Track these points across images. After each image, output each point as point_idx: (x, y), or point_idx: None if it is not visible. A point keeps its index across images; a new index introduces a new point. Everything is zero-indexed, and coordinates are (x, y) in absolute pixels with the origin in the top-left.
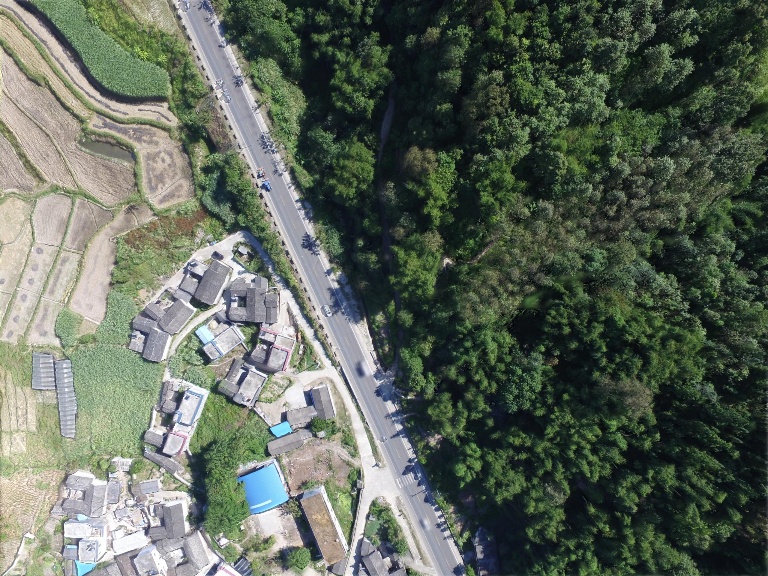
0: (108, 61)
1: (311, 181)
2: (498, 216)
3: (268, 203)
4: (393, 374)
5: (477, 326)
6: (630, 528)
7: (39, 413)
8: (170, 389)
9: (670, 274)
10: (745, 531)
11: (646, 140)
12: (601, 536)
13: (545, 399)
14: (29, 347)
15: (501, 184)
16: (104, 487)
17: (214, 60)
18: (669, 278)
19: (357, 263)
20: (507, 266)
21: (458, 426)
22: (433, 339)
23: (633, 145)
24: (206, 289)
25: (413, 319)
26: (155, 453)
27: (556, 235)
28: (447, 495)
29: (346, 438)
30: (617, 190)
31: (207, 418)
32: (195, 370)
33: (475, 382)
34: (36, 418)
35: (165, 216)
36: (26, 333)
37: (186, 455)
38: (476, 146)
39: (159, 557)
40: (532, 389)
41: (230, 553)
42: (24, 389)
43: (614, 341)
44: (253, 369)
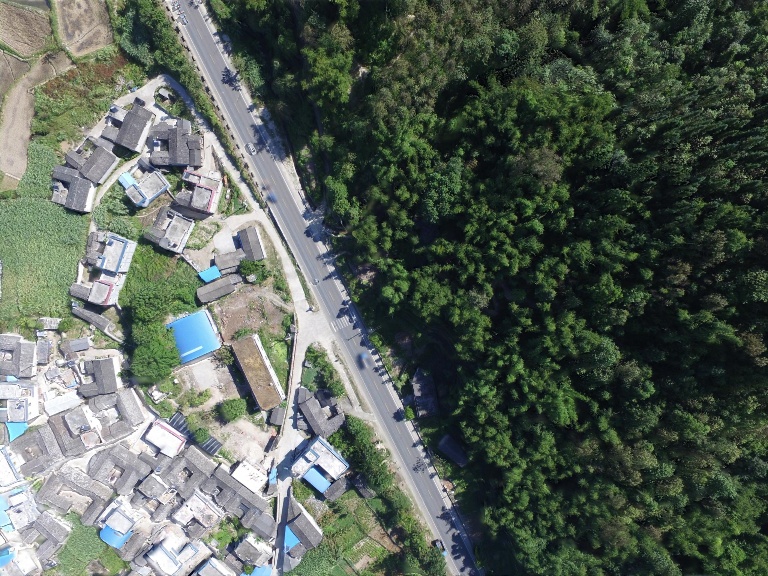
0: None
1: (228, 12)
2: None
3: (185, 37)
4: (322, 213)
5: (393, 128)
6: (551, 316)
7: None
8: (95, 240)
9: (587, 66)
10: (659, 293)
11: None
12: (525, 333)
13: (463, 195)
14: None
15: None
16: (32, 346)
17: None
18: (585, 68)
19: (278, 93)
20: (416, 54)
21: (383, 245)
22: (354, 157)
23: None
24: (126, 132)
25: (334, 140)
26: (84, 309)
27: (463, 14)
28: (379, 328)
29: (277, 282)
30: None
31: (135, 270)
32: (120, 219)
33: (397, 196)
34: None
35: (83, 63)
36: None
37: (116, 311)
38: None
39: (92, 415)
40: (451, 190)
41: (165, 408)
42: None
43: (528, 126)
44: None
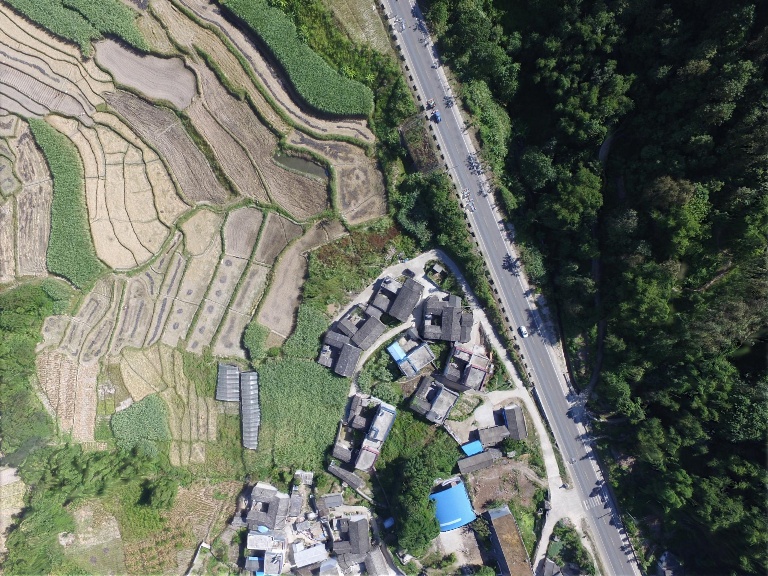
0: (316, 78)
1: (515, 203)
2: (762, 249)
3: (472, 223)
4: (586, 396)
5: (709, 355)
6: None
7: (220, 424)
8: (359, 404)
9: None
10: None
11: None
12: None
13: None
14: (214, 358)
15: None
16: (288, 500)
17: (426, 81)
18: None
19: (561, 286)
20: (753, 297)
21: (671, 452)
22: (649, 365)
23: None
24: (402, 307)
25: (625, 344)
26: (339, 467)
27: None
28: (644, 519)
29: (535, 459)
30: None
31: (393, 434)
32: (385, 386)
33: (693, 409)
34: (217, 429)
35: (358, 232)
36: (213, 344)
37: None
38: (741, 179)
39: (341, 571)
40: (763, 419)
41: (412, 569)
42: (207, 400)
43: None
44: (444, 387)
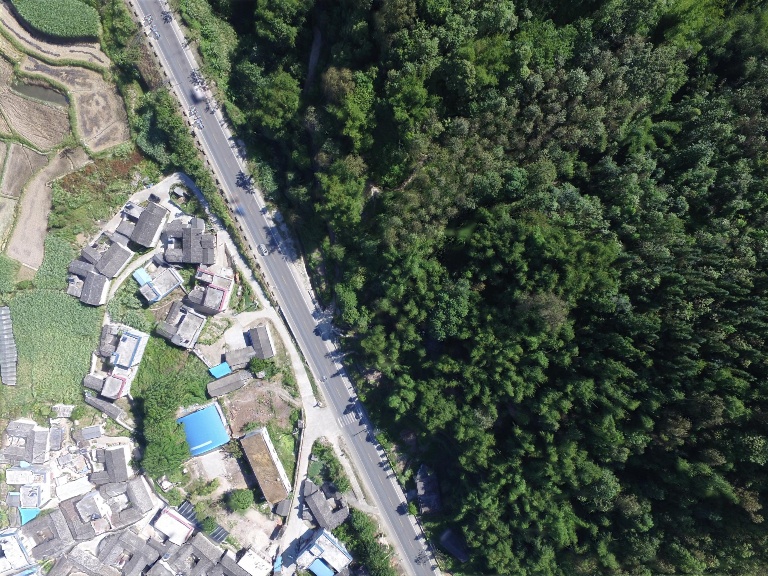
0: None
1: (243, 118)
2: (413, 132)
3: (201, 141)
4: (331, 313)
5: (403, 252)
6: (554, 446)
7: None
8: (109, 333)
9: (594, 196)
10: (660, 439)
11: (558, 51)
12: (527, 457)
13: (470, 322)
14: None
15: (413, 98)
16: (45, 433)
17: None
18: (592, 199)
19: (291, 199)
20: (428, 187)
21: (391, 357)
22: (364, 270)
23: (545, 57)
24: (141, 230)
25: (345, 252)
26: (96, 398)
27: (474, 153)
28: (385, 430)
29: (286, 378)
30: (533, 105)
31: (147, 362)
32: (134, 313)
33: (406, 312)
34: None
35: (100, 159)
36: None
37: (128, 400)
38: (390, 62)
39: (102, 502)
40: (459, 314)
41: (173, 496)
42: None
43: (535, 260)
44: (191, 311)
